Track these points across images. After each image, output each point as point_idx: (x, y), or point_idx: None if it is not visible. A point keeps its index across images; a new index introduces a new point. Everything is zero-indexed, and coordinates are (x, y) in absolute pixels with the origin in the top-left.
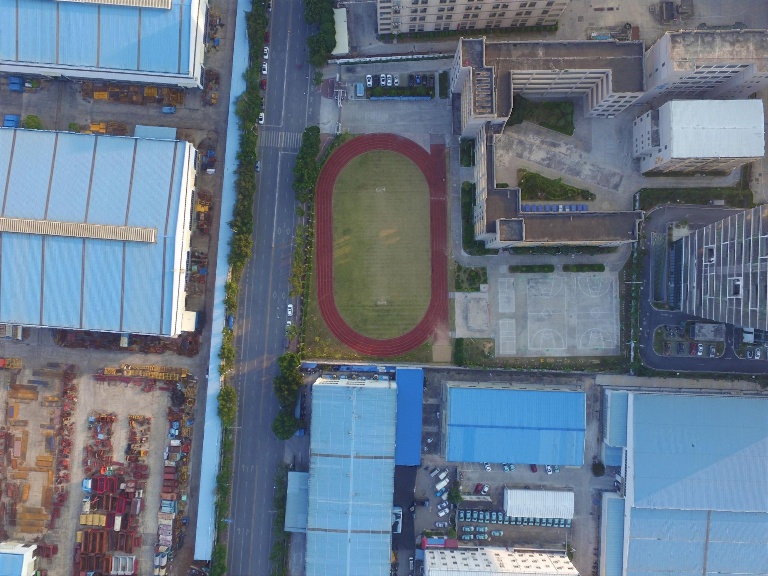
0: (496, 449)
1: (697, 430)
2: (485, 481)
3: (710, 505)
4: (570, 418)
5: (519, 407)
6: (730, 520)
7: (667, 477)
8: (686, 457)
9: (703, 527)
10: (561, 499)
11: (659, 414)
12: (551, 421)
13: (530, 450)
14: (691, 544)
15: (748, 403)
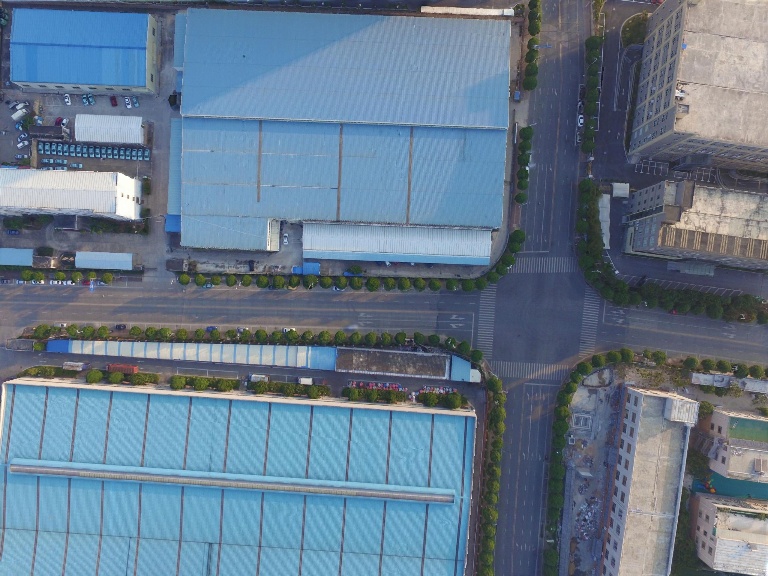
0: (59, 68)
1: (249, 42)
2: (66, 116)
3: (257, 112)
4: (132, 37)
5: (82, 27)
6: (281, 131)
7: (216, 86)
8: (236, 67)
9: (255, 138)
10: (128, 122)
11: (213, 27)
12: (113, 40)
13: (93, 69)
14: (244, 156)
15: (302, 17)
